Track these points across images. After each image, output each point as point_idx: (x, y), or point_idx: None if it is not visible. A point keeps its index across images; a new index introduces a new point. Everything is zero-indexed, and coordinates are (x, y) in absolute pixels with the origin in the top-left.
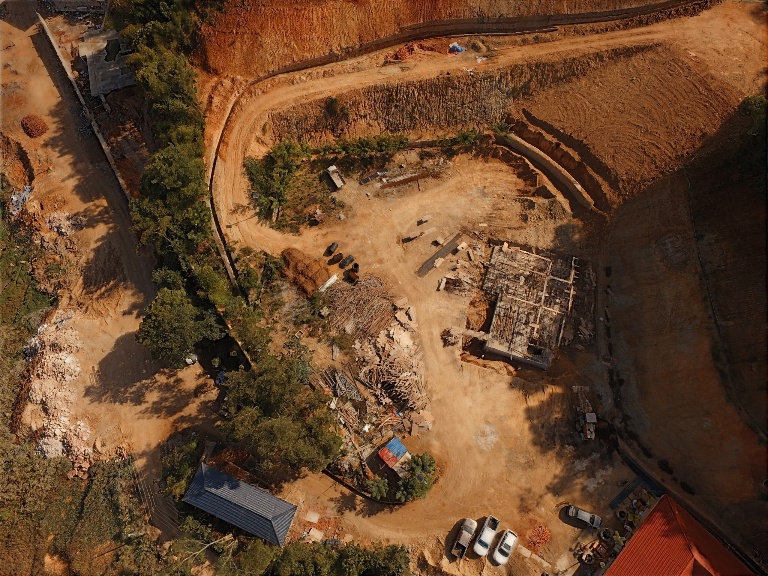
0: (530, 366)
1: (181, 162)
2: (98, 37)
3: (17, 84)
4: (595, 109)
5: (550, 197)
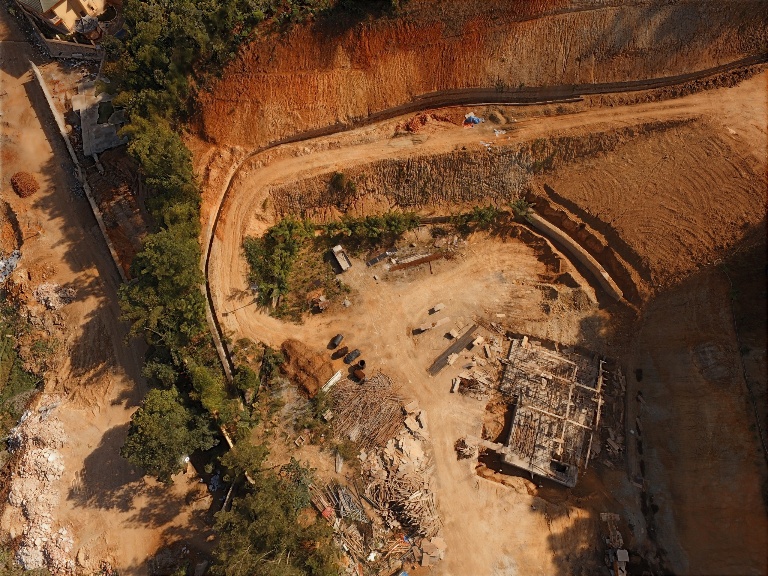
0: (553, 483)
1: (174, 249)
2: (93, 89)
3: (8, 137)
4: (624, 189)
5: (574, 286)
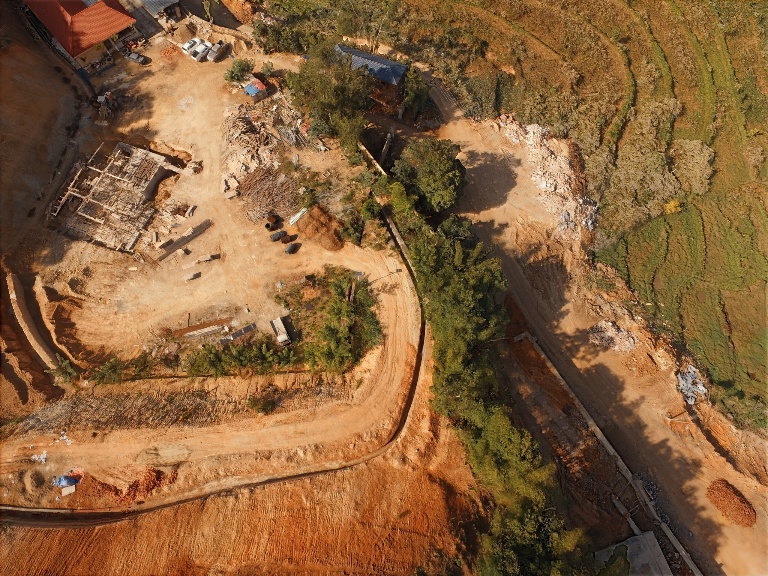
0: None
1: None
2: None
3: None
4: None
5: (49, 289)
